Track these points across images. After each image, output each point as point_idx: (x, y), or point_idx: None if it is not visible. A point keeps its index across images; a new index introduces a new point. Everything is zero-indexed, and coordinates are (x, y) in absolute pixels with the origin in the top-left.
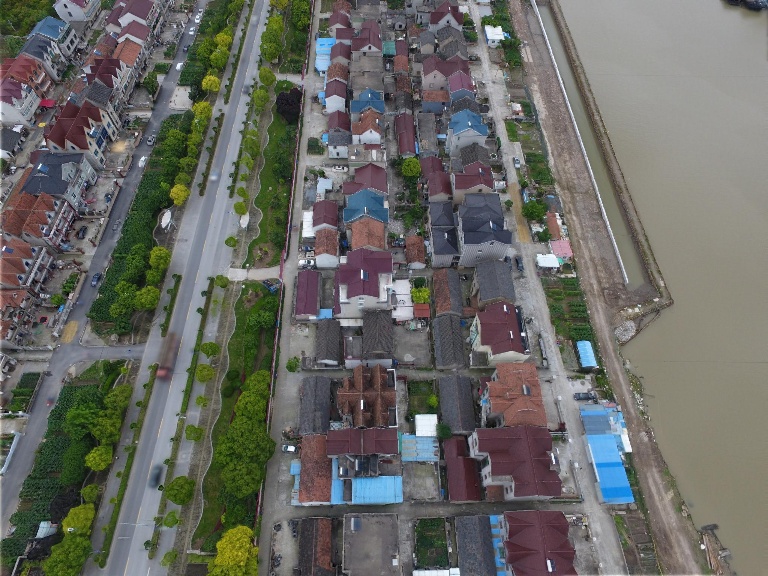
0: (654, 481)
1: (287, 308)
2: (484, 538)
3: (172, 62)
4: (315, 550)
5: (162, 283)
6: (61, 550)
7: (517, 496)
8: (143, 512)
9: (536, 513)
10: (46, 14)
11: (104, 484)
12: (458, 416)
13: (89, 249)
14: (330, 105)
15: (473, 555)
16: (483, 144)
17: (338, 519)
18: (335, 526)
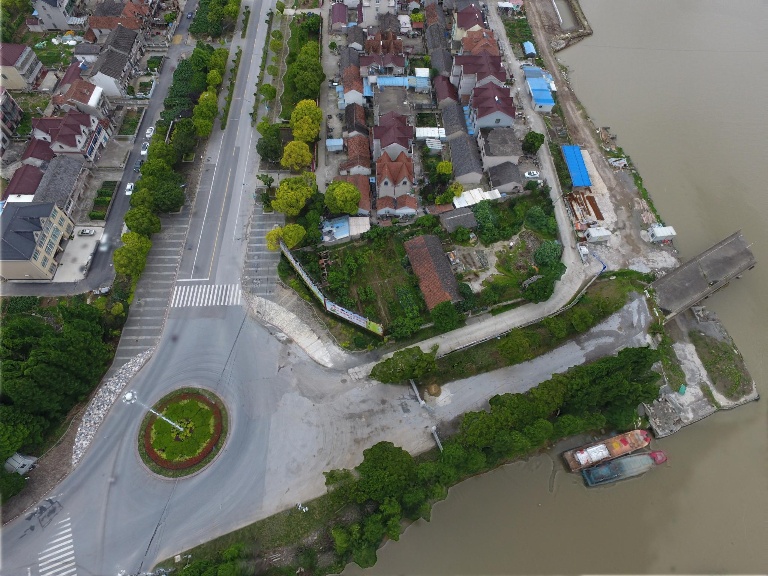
0: (570, 106)
1: (325, 27)
2: (459, 112)
3: None
4: (355, 114)
5: None
6: (203, 102)
7: (479, 80)
8: (244, 110)
9: (490, 83)
10: None
11: (217, 98)
12: (443, 65)
13: (181, 1)
14: None
15: (453, 119)
16: None
17: (368, 109)
18: (366, 112)
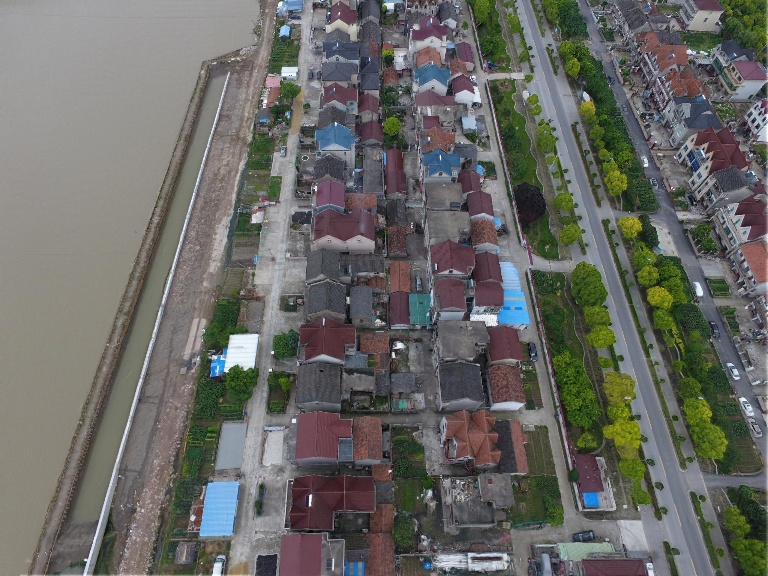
0: None
1: (477, 59)
2: None
3: (715, 302)
4: None
5: None
6: None
7: None
8: None
9: None
10: None
11: (542, 3)
12: (372, 3)
13: None
14: None
15: None
16: None
17: None
18: None
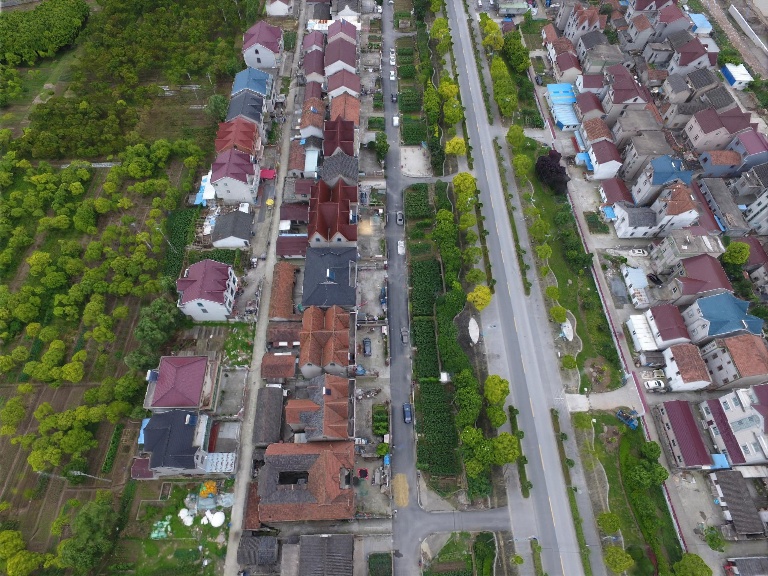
0: None
1: None
2: None
3: (384, 115)
4: None
5: None
6: None
7: None
8: None
9: None
10: (236, 62)
11: None
12: None
13: (382, 369)
14: (601, 170)
15: None
16: None
17: None
18: None
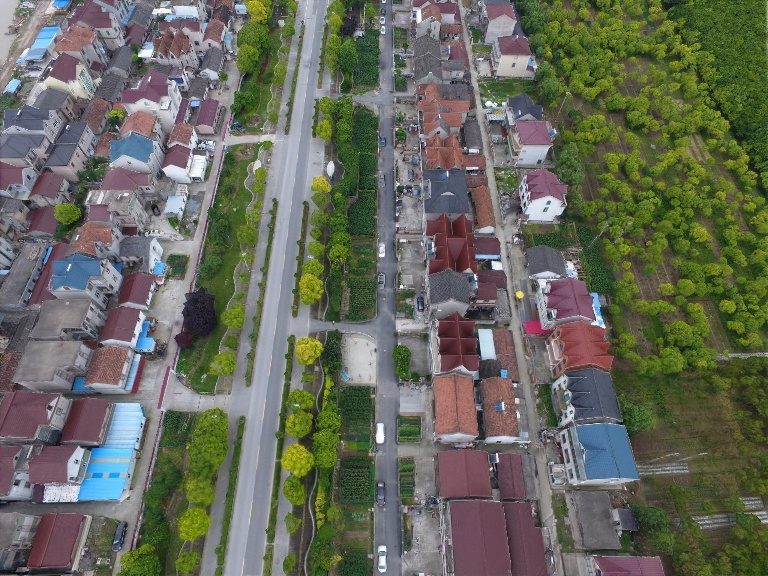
0: (24, 44)
1: (228, 117)
2: None
3: (398, 450)
4: None
5: None
6: (335, 8)
7: None
8: (311, 37)
9: None
10: (658, 533)
11: None
12: (122, 51)
13: (400, 164)
14: None
15: None
16: None
17: None
18: None
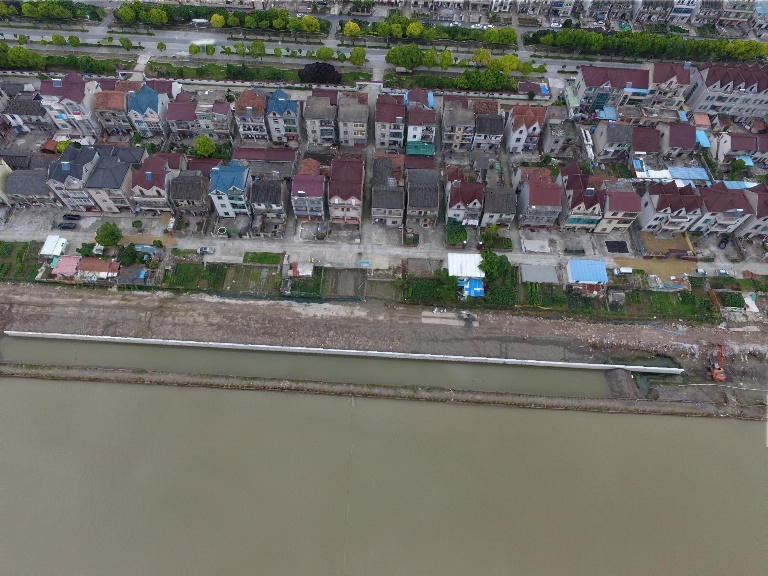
0: None
1: None
2: None
3: None
4: None
5: (151, 29)
6: None
7: None
8: None
9: None
10: None
11: (25, 22)
12: None
13: (199, 3)
14: None
15: None
16: (214, 201)
17: None
18: None
